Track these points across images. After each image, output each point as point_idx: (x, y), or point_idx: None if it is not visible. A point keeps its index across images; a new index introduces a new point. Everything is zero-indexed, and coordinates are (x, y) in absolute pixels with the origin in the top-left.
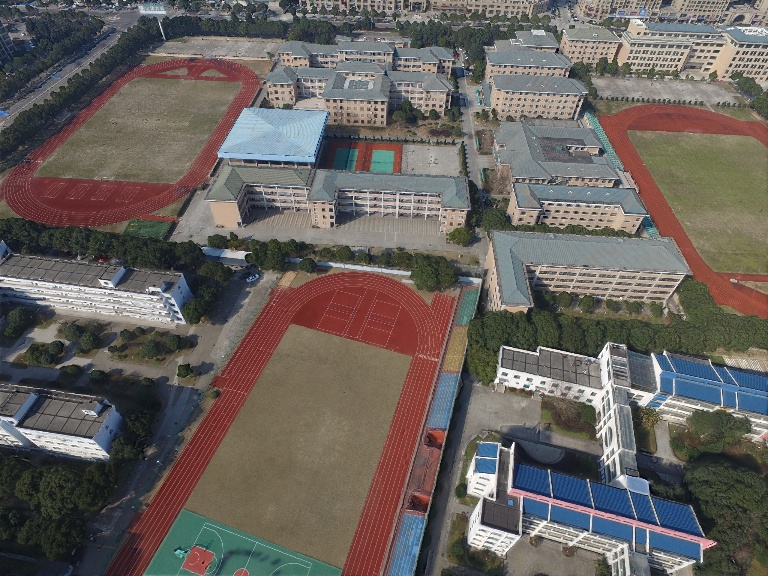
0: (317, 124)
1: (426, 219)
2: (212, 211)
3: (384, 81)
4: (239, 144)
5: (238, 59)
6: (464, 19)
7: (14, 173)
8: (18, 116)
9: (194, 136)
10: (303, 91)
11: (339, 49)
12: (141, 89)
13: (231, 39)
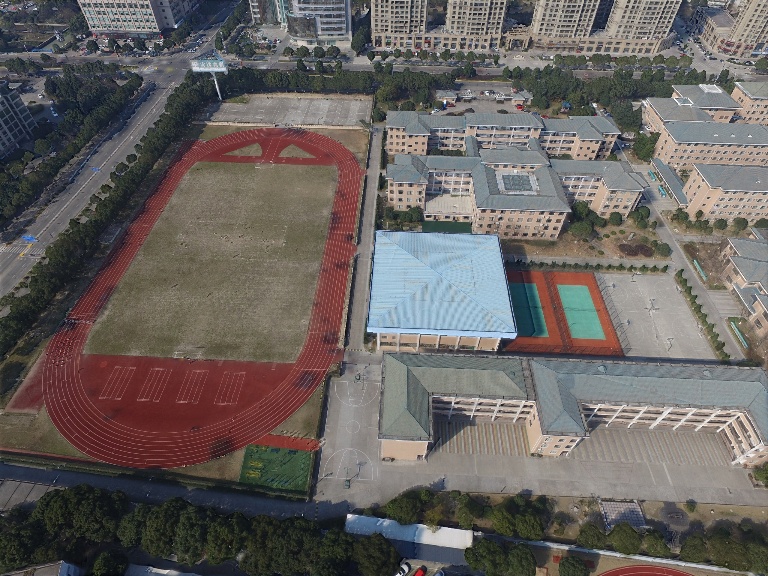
0: (493, 262)
1: (697, 431)
2: (383, 445)
3: (553, 177)
4: (395, 309)
5: (321, 128)
6: (584, 62)
7: (54, 348)
8: (53, 251)
9: (299, 265)
10: (432, 186)
11: (470, 124)
12: (207, 181)
13: (303, 96)
